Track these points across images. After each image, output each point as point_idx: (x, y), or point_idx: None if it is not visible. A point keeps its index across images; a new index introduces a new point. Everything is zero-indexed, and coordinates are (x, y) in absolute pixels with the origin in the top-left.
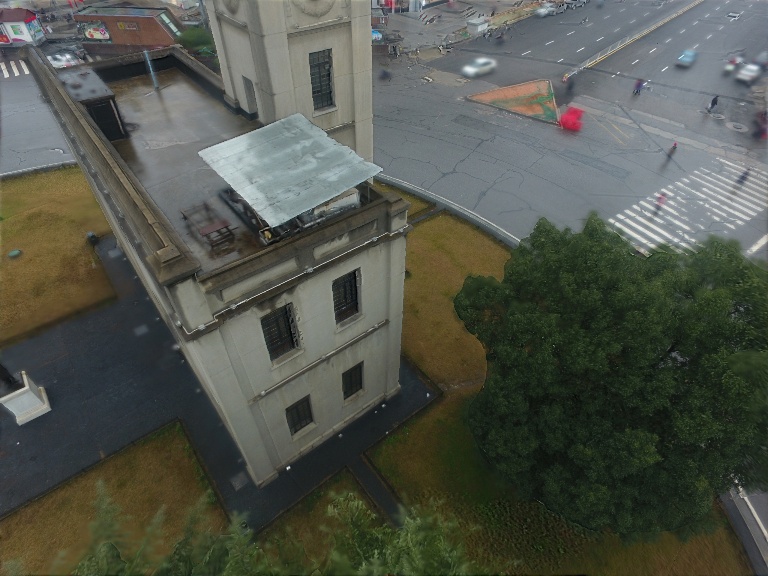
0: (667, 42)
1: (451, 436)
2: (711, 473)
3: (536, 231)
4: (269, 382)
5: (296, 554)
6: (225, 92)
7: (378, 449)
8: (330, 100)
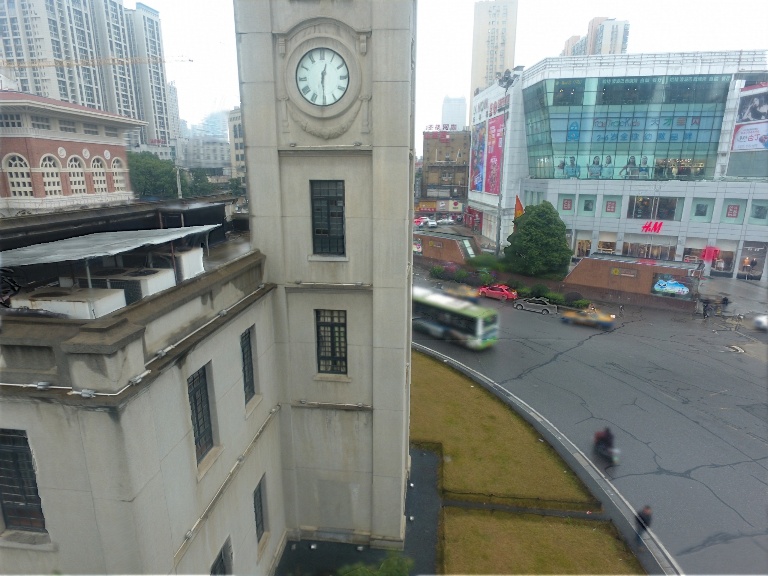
0: None
1: None
2: None
3: None
4: None
5: None
6: None
7: None
8: (342, 248)
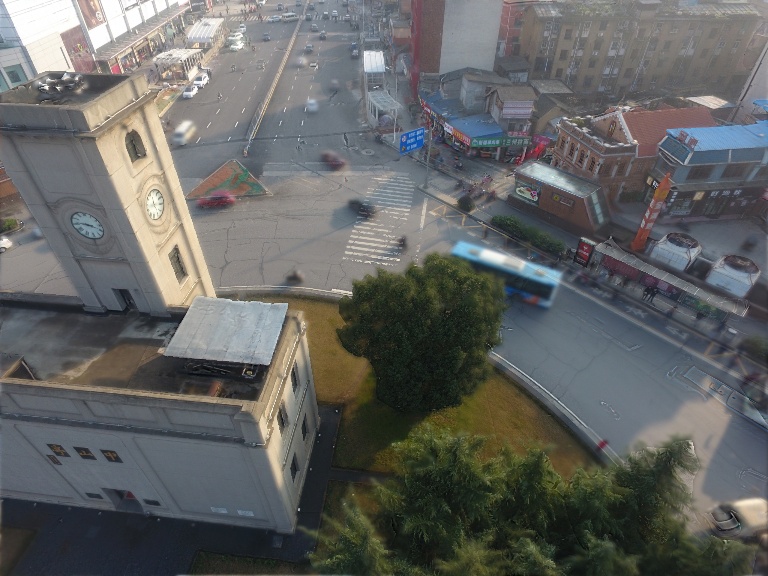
0: (289, 100)
1: (366, 421)
2: (481, 347)
3: (356, 288)
4: (283, 455)
5: (378, 498)
6: (84, 305)
7: (337, 458)
8: (183, 273)
